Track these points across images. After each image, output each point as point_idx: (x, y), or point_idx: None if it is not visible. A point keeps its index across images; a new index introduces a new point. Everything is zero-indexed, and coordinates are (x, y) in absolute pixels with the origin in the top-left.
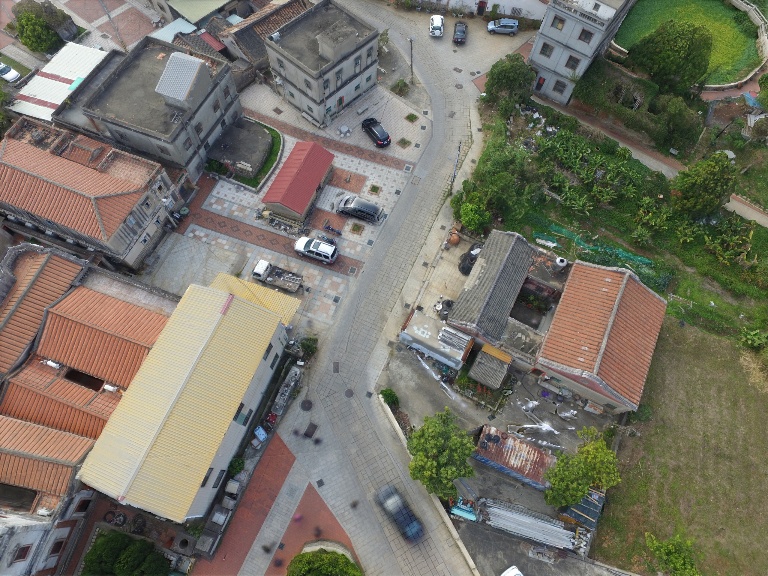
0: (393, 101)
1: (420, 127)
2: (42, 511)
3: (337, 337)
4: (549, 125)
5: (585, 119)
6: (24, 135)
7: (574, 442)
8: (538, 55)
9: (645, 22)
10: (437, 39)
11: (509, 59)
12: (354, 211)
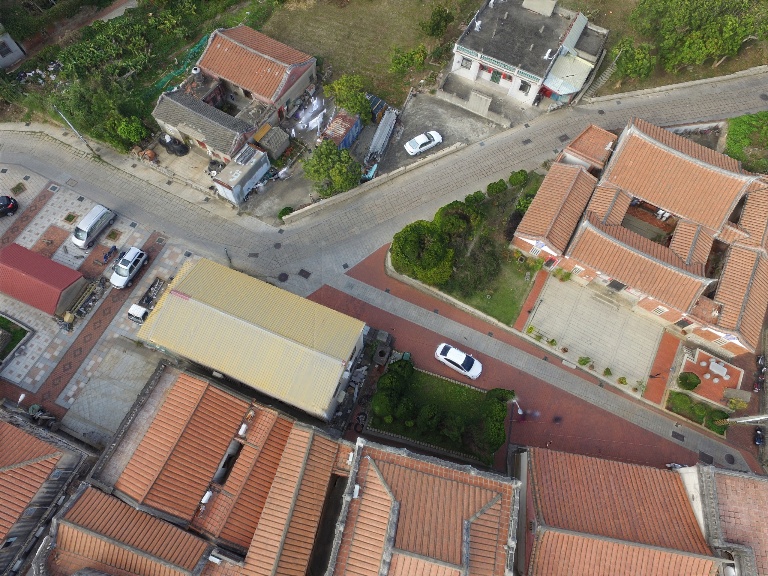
0: None
1: (2, 174)
2: (349, 459)
3: (225, 254)
4: None
5: None
6: None
7: (332, 107)
8: None
9: None
10: None
11: None
12: (93, 231)
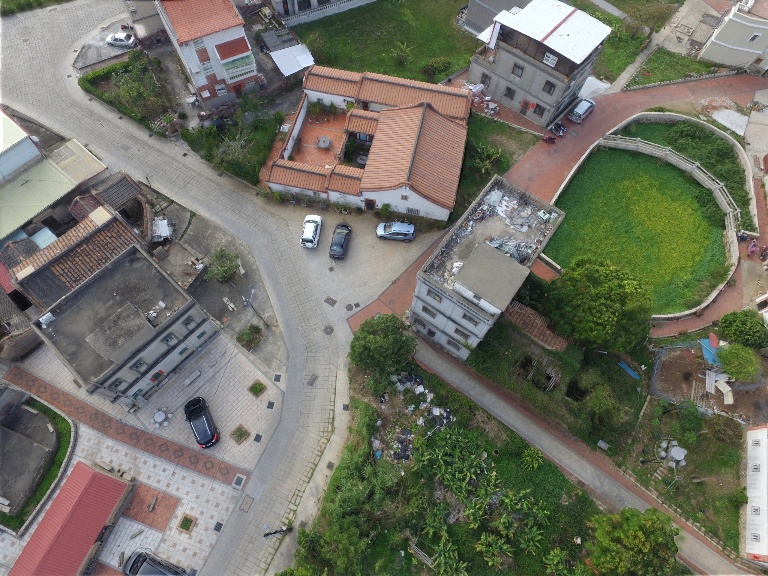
0: (237, 359)
1: (266, 404)
2: None
3: None
4: (436, 405)
5: (489, 385)
6: None
7: None
8: (421, 311)
9: (583, 206)
10: (311, 250)
11: (376, 328)
12: None
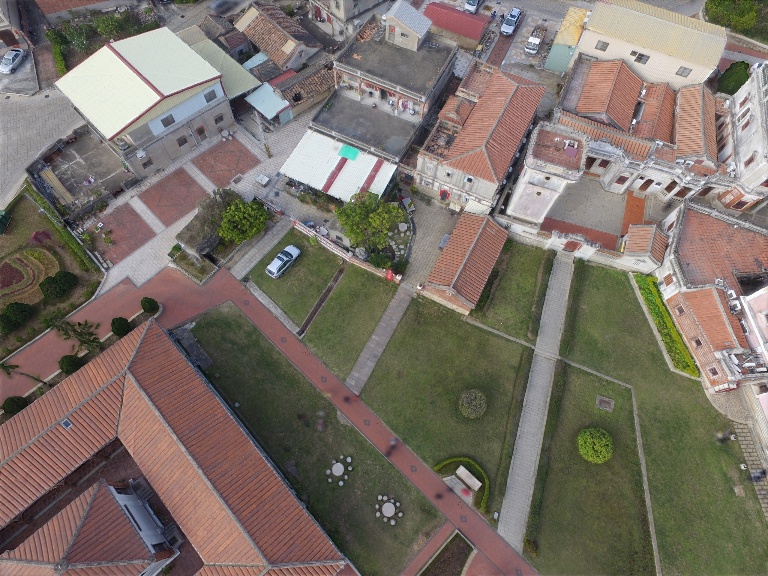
0: None
1: None
2: (727, 103)
3: None
4: None
5: None
6: (438, 154)
7: None
8: None
9: None
10: None
11: None
12: (480, 1)
